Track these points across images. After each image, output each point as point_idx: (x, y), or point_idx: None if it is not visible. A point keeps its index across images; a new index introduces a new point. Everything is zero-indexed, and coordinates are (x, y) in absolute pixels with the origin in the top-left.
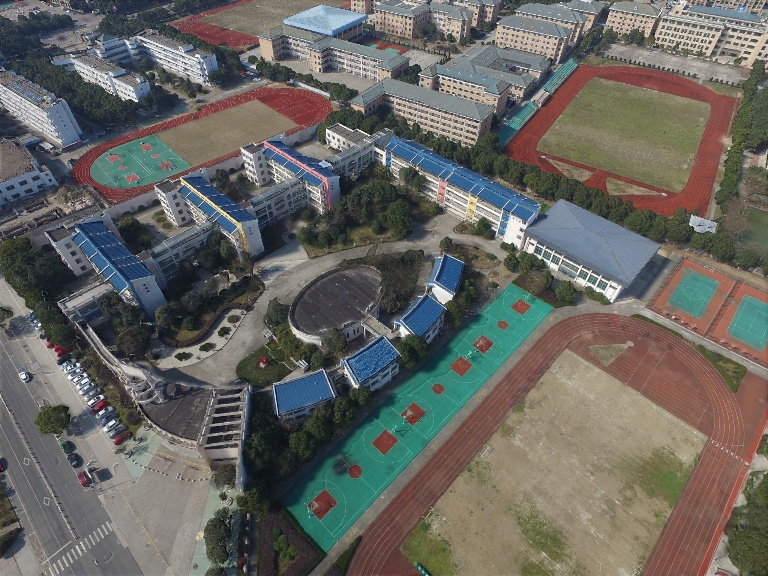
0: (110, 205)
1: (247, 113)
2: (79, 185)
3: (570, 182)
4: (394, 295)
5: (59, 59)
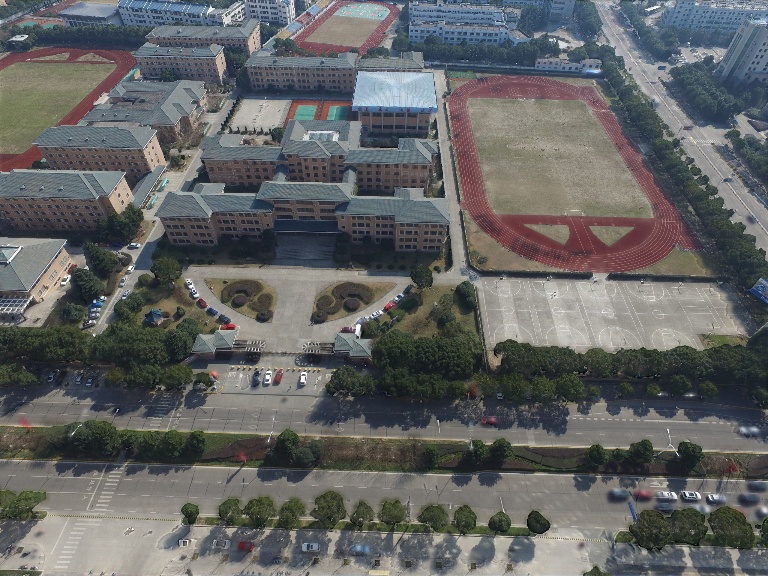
0: None
1: (350, 39)
2: (372, 1)
3: (97, 27)
4: None
5: (511, 9)
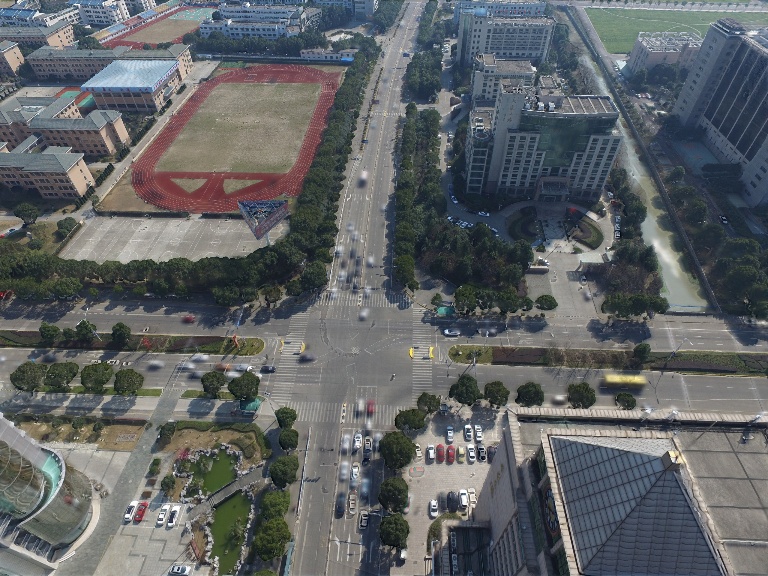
0: (182, 1)
1: (162, 37)
2: (213, 6)
3: None
4: None
5: (312, 9)
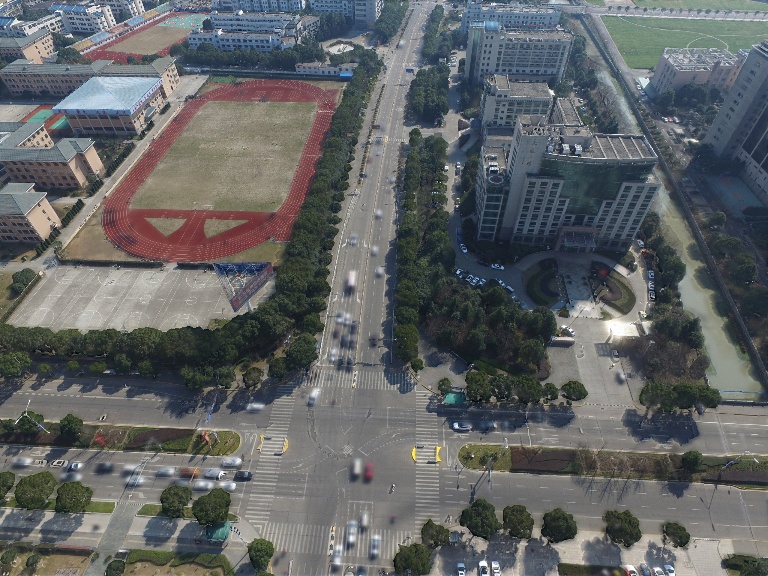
0: (173, 6)
1: (149, 47)
2: None
3: None
4: (22, 2)
5: (309, 17)
